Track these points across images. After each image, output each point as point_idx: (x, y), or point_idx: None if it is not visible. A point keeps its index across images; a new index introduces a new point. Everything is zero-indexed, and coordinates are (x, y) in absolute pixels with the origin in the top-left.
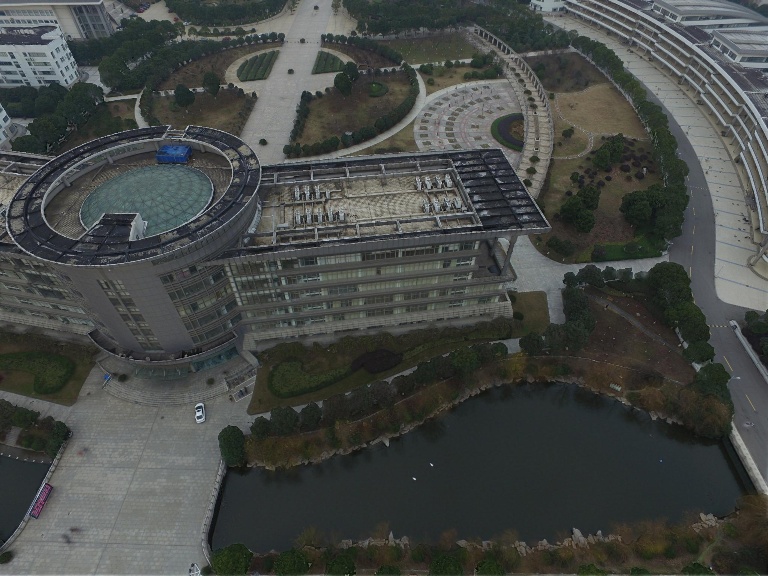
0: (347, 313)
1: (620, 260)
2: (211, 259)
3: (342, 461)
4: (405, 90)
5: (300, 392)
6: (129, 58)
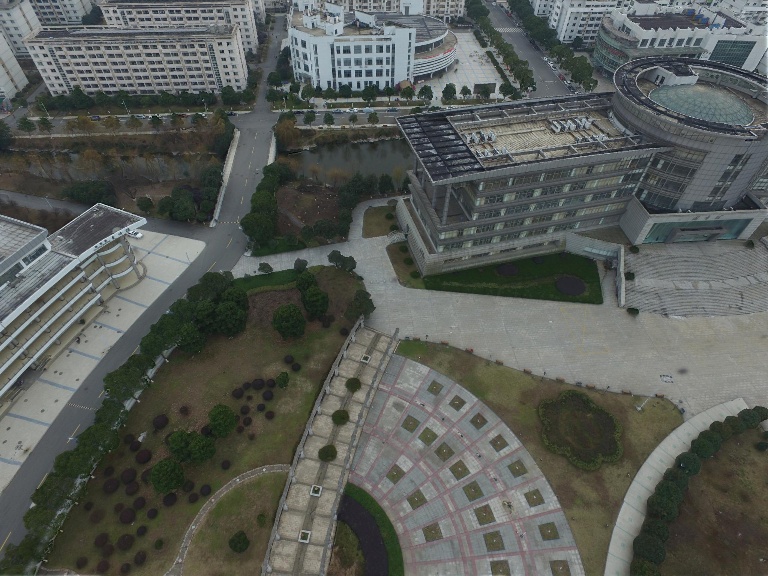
0: None
1: None
2: None
3: None
4: None
5: None
6: None
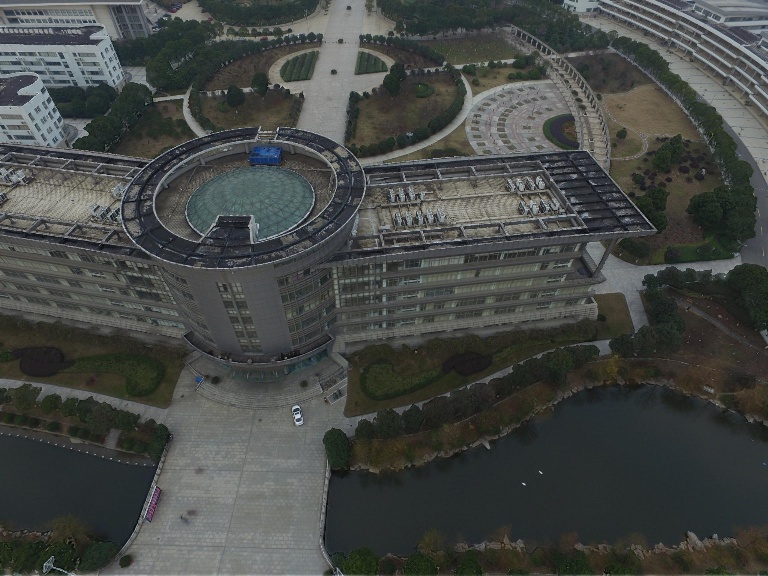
0: (438, 315)
1: (693, 262)
2: (323, 261)
3: (437, 464)
4: (451, 91)
5: (395, 394)
6: (173, 58)
